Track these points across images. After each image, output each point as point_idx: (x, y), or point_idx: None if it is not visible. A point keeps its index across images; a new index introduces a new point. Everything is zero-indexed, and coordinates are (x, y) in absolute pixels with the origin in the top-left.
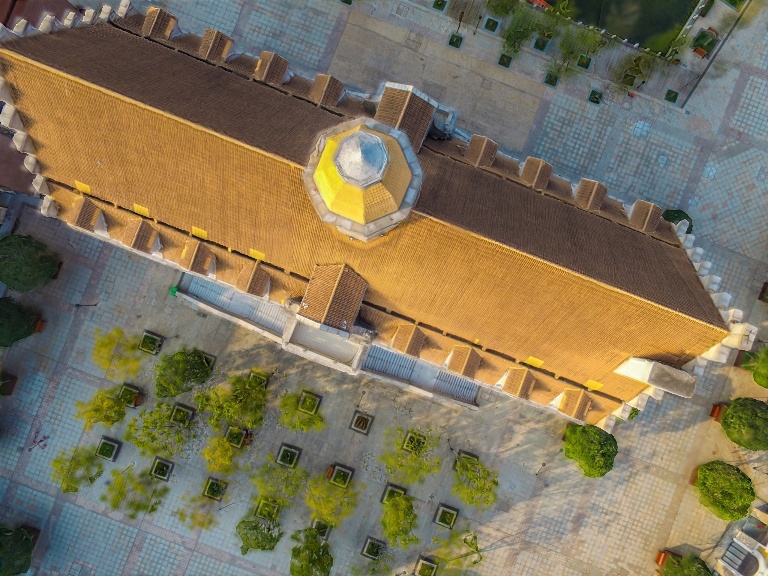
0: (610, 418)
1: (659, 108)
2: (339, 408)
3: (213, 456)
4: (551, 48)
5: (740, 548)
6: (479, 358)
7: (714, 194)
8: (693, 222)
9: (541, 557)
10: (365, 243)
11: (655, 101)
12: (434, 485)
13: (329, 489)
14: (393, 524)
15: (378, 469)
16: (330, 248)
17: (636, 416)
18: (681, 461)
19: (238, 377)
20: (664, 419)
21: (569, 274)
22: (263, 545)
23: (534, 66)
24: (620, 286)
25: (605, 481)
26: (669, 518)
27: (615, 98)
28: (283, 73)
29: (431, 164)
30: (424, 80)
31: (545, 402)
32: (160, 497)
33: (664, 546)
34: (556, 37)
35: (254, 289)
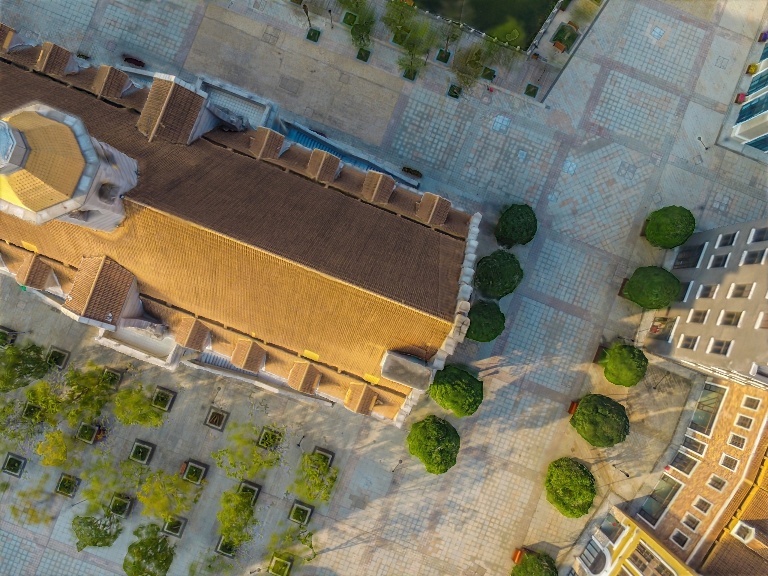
0: (401, 413)
1: (519, 103)
2: (194, 404)
3: (47, 452)
4: (410, 42)
5: (595, 546)
6: (263, 352)
7: (574, 189)
8: (553, 217)
9: (397, 554)
10: (110, 234)
11: (515, 96)
12: (290, 482)
13: (183, 486)
14: (224, 520)
15: (233, 466)
16: (85, 240)
17: (494, 413)
18: (539, 458)
19: (92, 373)
20: (522, 416)
21: (293, 265)
22: (95, 541)
23: (393, 60)
24: (345, 277)
25: (462, 478)
26: (527, 515)
27: (474, 92)
28: (66, 64)
29: (198, 155)
30: (281, 74)
31: (341, 397)
32: (12, 493)
33: (522, 544)
34: (415, 31)
35: (33, 282)
